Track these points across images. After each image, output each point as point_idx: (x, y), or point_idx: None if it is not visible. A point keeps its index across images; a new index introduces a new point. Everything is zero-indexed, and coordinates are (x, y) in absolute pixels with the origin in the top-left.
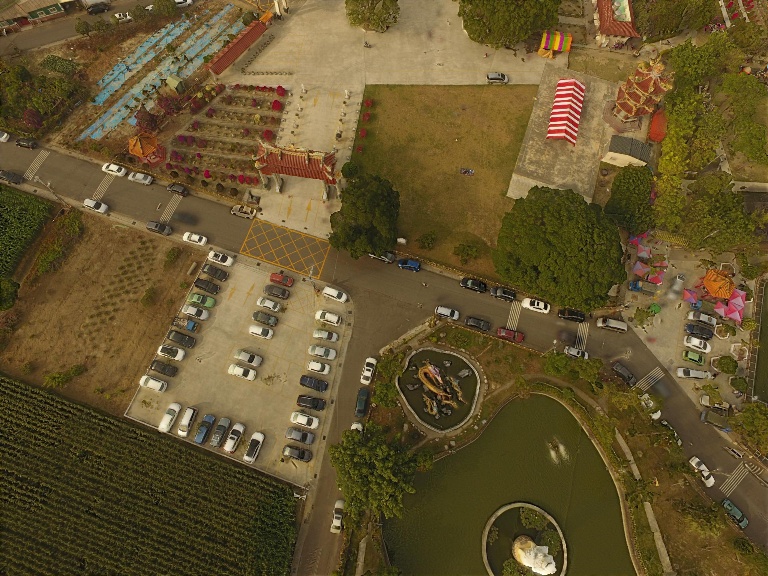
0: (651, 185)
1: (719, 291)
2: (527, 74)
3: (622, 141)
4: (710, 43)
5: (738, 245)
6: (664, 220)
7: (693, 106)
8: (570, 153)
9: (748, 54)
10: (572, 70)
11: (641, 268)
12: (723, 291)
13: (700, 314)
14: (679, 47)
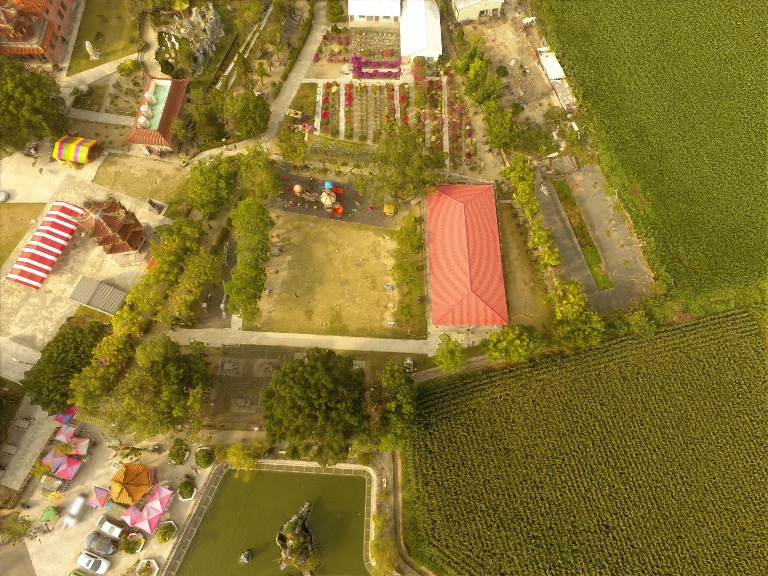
0: (92, 347)
1: (121, 496)
2: (38, 189)
3: (88, 285)
4: (239, 159)
5: (209, 419)
6: (71, 401)
7: (176, 244)
8: (46, 294)
9: (326, 163)
10: (96, 184)
11: (51, 457)
12: (126, 496)
13: (104, 521)
14: (197, 164)
